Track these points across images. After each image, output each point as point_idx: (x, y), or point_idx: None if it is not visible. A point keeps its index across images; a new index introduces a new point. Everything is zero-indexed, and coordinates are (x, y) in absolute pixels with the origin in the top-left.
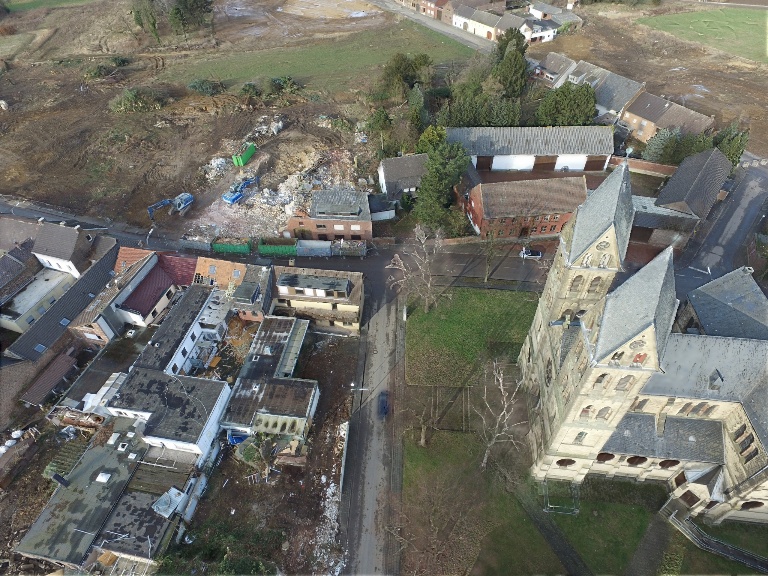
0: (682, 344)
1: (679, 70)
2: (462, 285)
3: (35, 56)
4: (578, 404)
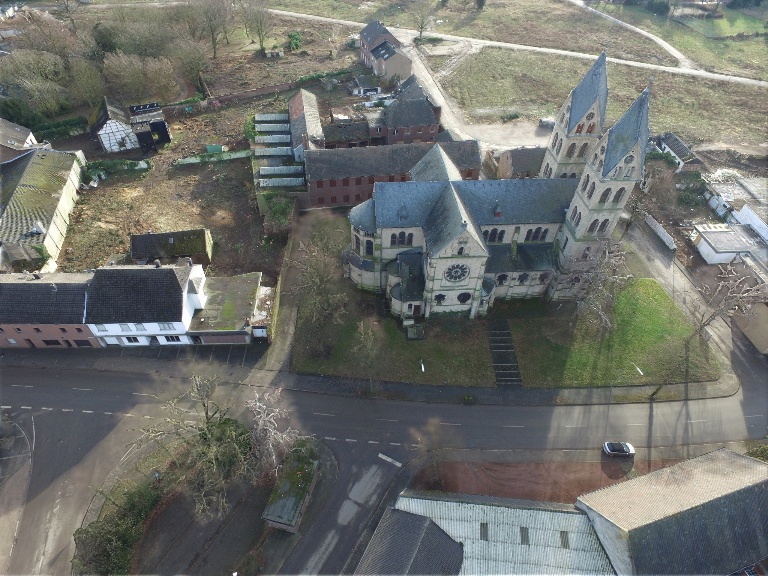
0: None
1: None
2: (675, 386)
3: None
4: None
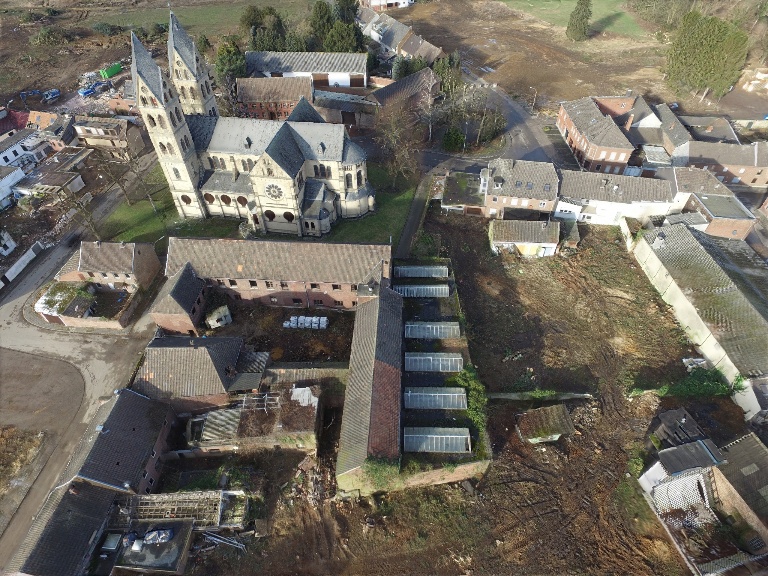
0: (231, 123)
1: (488, 29)
2: None
3: None
4: (154, 141)
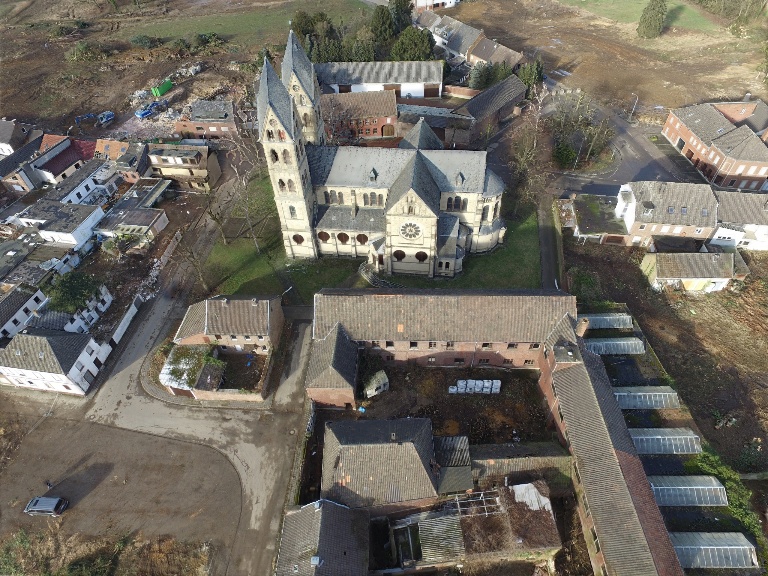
0: (353, 153)
1: (547, 28)
2: None
3: (12, 21)
4: (273, 178)
